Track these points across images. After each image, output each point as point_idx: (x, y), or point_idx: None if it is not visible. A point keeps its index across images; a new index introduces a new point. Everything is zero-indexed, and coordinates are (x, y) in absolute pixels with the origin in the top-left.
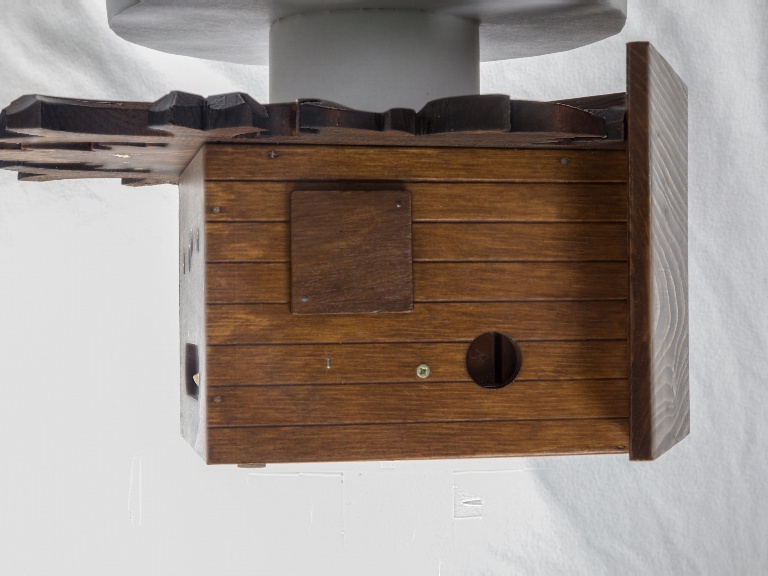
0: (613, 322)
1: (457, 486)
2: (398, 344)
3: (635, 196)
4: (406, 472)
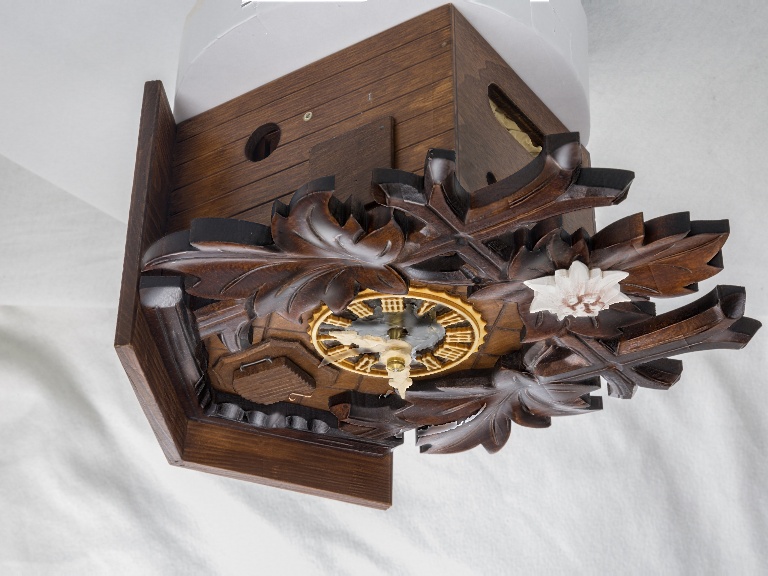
0: (185, 196)
1: (255, 8)
2: (324, 127)
3: (137, 240)
4: (287, 5)
